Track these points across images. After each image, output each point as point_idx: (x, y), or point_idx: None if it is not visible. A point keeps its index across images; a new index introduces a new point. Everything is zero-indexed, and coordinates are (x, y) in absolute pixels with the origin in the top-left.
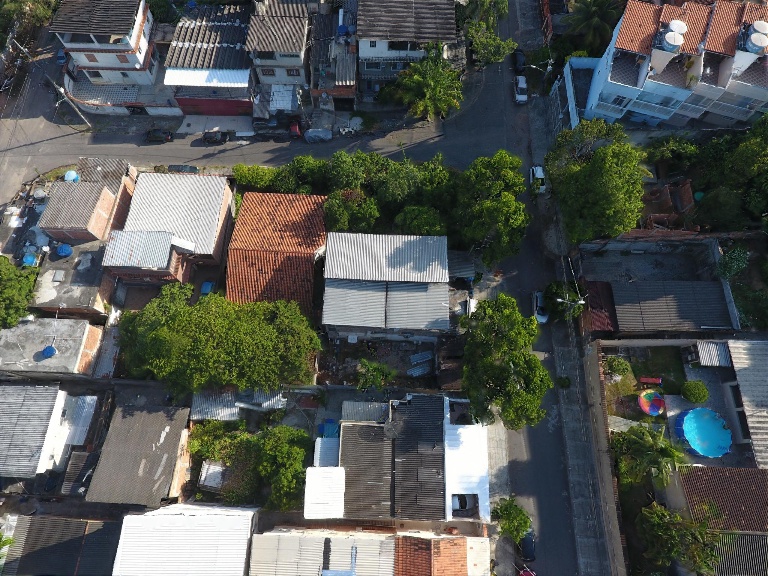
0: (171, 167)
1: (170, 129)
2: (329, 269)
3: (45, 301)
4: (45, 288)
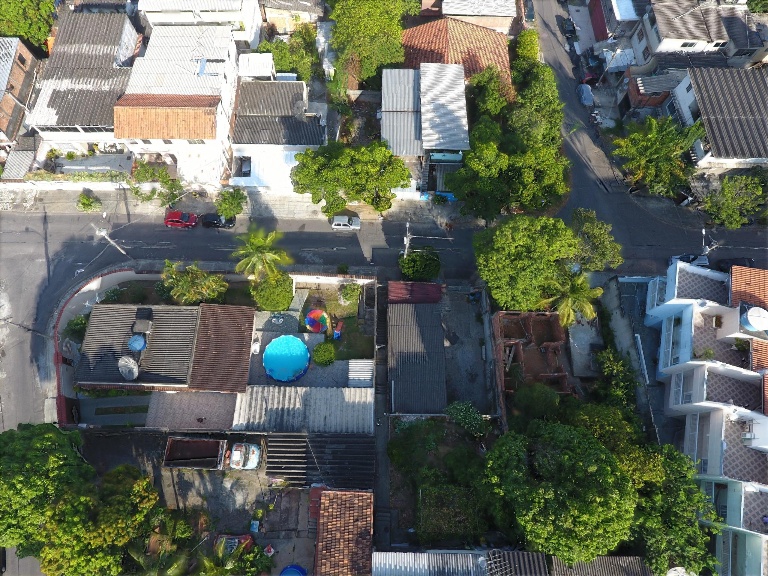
0: (530, 1)
1: (571, 0)
2: (428, 65)
3: None
4: None
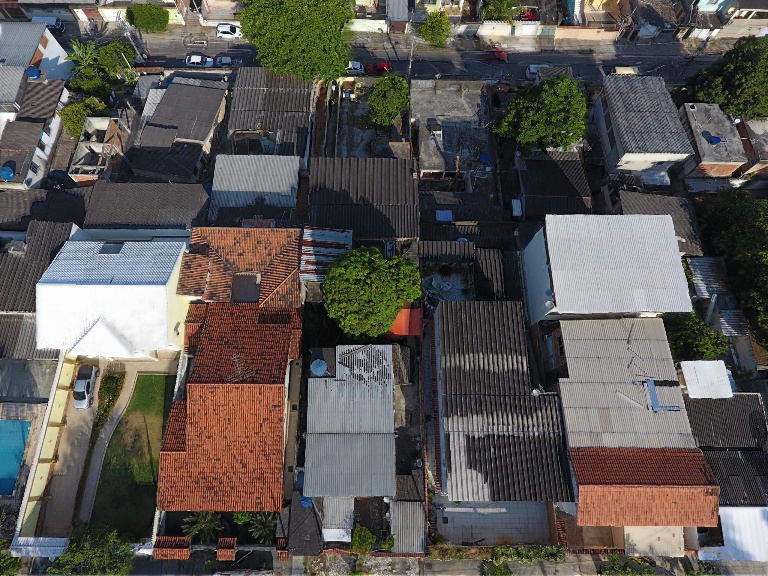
0: None
1: None
2: None
3: (752, 127)
4: (762, 125)
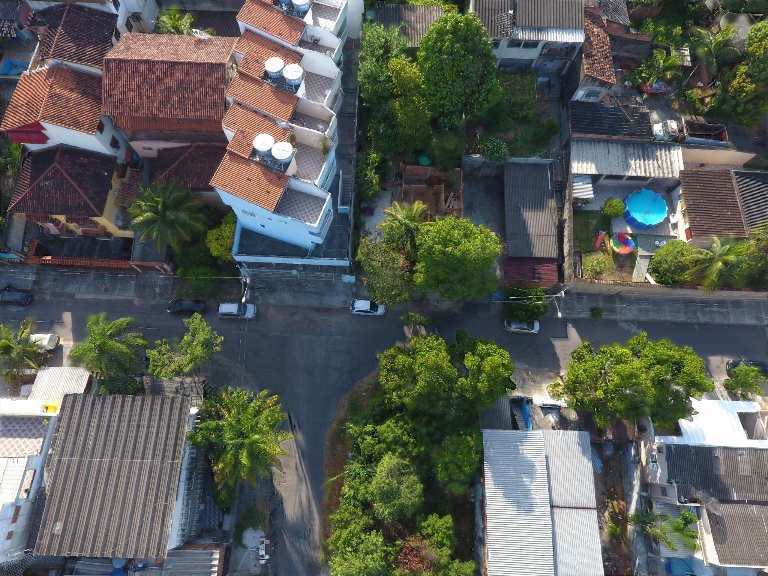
0: None
1: None
2: None
3: None
4: None
